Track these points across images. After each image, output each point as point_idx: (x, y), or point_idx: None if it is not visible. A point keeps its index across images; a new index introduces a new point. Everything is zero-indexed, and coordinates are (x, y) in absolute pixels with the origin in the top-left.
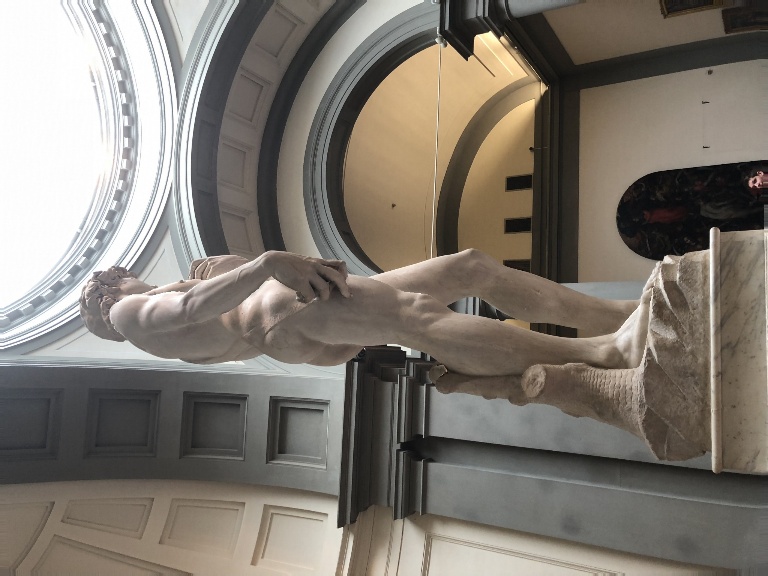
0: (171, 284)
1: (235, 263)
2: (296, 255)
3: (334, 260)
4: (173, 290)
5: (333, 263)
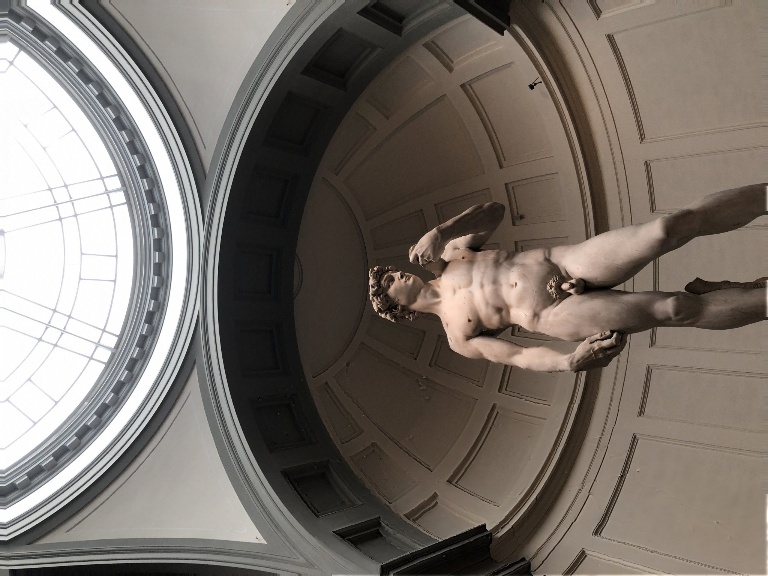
0: (466, 326)
1: (440, 246)
2: (587, 358)
3: (609, 344)
4: (474, 330)
5: (611, 346)
